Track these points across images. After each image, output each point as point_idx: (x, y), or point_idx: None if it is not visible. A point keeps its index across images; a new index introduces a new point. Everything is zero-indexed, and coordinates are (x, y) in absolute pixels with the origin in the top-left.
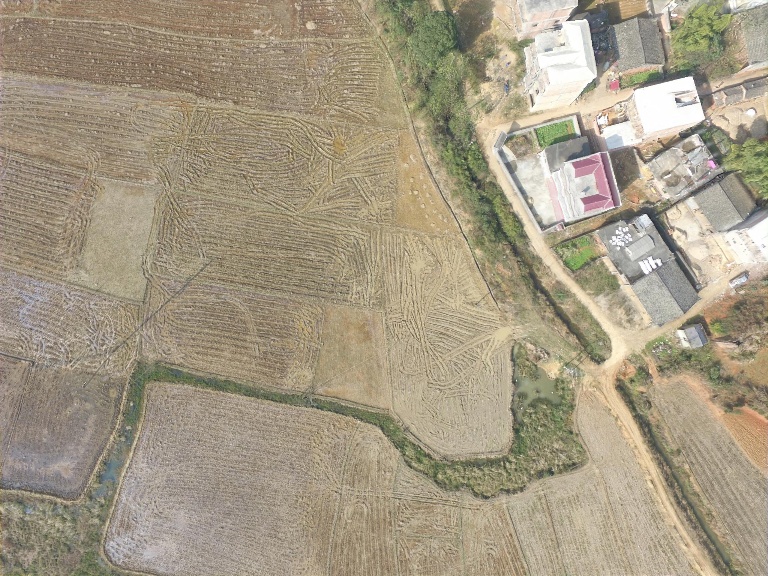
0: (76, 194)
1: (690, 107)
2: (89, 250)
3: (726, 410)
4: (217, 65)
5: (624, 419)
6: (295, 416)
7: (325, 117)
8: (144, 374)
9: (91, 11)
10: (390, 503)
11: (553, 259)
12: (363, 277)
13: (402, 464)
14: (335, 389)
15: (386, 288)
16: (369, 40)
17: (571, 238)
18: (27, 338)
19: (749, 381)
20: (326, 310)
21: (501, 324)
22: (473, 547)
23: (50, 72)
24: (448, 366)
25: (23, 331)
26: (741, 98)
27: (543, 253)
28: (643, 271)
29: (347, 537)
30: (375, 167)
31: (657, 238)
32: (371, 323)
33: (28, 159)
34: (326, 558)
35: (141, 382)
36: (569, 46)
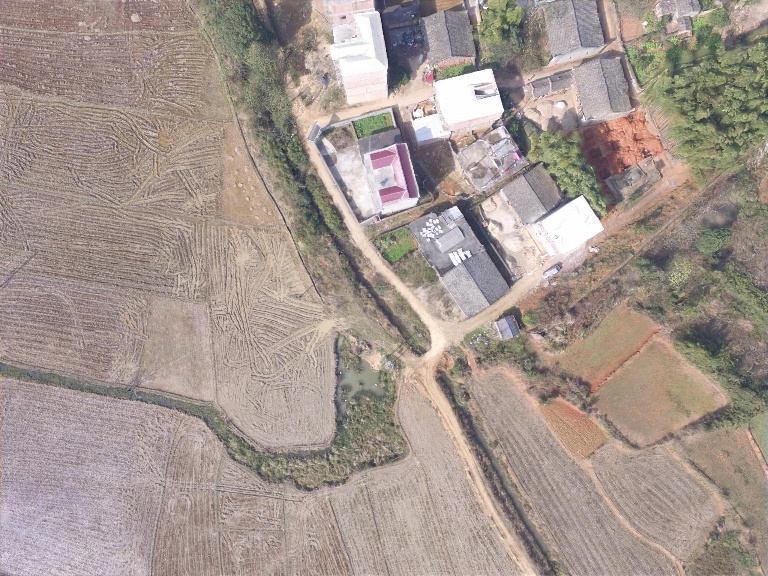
0: None
1: (489, 99)
2: None
3: (539, 401)
4: (42, 57)
5: (444, 411)
6: (119, 409)
7: (150, 110)
8: None
9: None
10: (213, 496)
11: (373, 251)
12: (188, 270)
13: (226, 457)
14: (159, 382)
15: (210, 281)
16: (194, 33)
17: (389, 230)
18: None
19: (564, 372)
20: (151, 303)
21: (325, 316)
22: (295, 539)
23: None
24: (272, 358)
25: None
26: (548, 90)
27: (363, 245)
28: (453, 263)
29: (170, 530)
30: (200, 160)
31: (467, 230)
32: (196, 316)
33: None
34: (149, 551)
35: None
36: (360, 38)
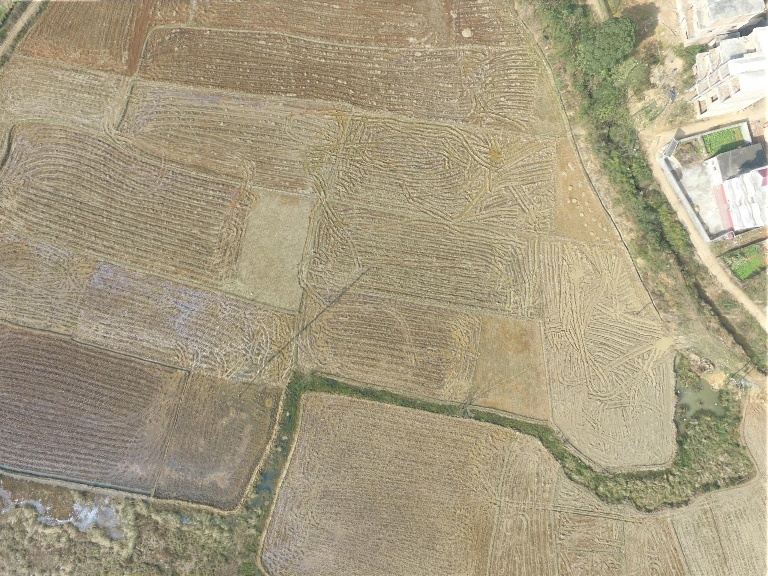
0: (231, 203)
1: None
2: (244, 259)
3: None
4: (372, 74)
5: None
6: (452, 427)
7: (481, 125)
8: (300, 384)
9: (246, 21)
10: (550, 516)
11: (720, 268)
12: (521, 286)
13: (562, 476)
14: (493, 400)
15: (545, 298)
16: (526, 47)
17: (739, 247)
18: (183, 347)
19: None
20: (483, 320)
21: (663, 334)
22: (636, 561)
23: (206, 82)
24: (609, 377)
25: (179, 340)
26: None
27: (709, 262)
28: None
29: (506, 550)
30: (533, 175)
31: None
32: (529, 333)
33: (184, 169)
34: (485, 571)
35: (297, 392)
36: (761, 52)
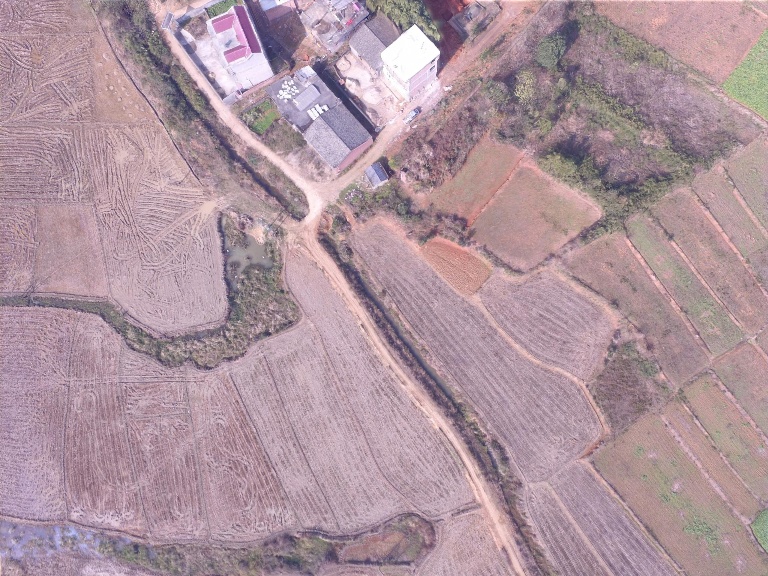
0: None
1: None
2: None
3: (418, 242)
4: None
5: (330, 270)
6: (18, 316)
7: (20, 32)
8: None
9: None
10: (117, 388)
11: (241, 127)
12: (70, 174)
13: (125, 348)
14: (54, 285)
15: (93, 181)
16: None
17: (253, 104)
18: None
19: (439, 212)
20: (39, 211)
21: (205, 199)
22: (201, 419)
23: None
24: (159, 246)
25: None
26: None
27: (231, 123)
28: (312, 119)
29: (79, 428)
30: (71, 70)
31: (322, 86)
32: (83, 217)
33: None
34: (60, 452)
35: None
36: None
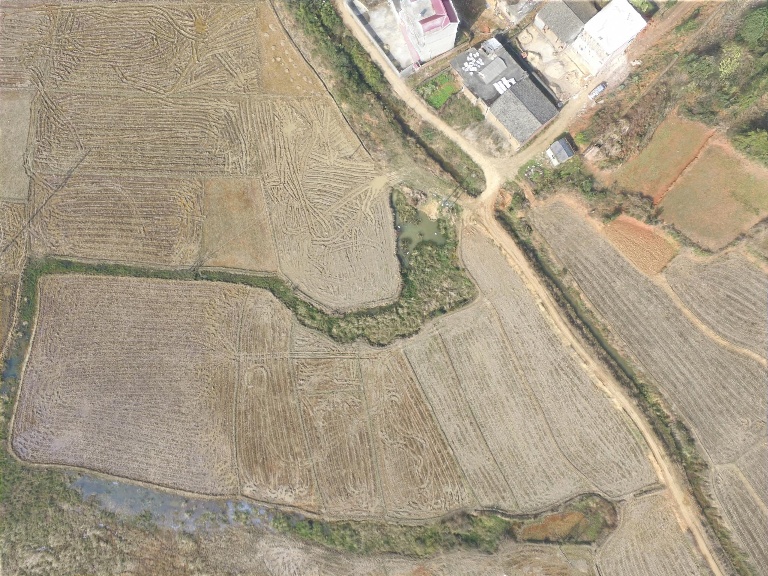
0: None
1: None
2: None
3: (603, 220)
4: None
5: (507, 247)
6: (186, 290)
7: (184, 1)
8: (35, 269)
9: None
10: (288, 363)
11: (416, 101)
12: (237, 147)
13: (296, 323)
14: (222, 259)
15: (260, 154)
16: None
17: (430, 77)
18: None
19: (623, 190)
20: (205, 184)
21: (376, 173)
22: (375, 396)
23: None
24: (330, 221)
25: None
26: None
27: (406, 96)
28: (498, 92)
29: (250, 403)
30: (237, 41)
31: (508, 59)
32: (250, 190)
33: None
34: (231, 427)
35: (33, 277)
36: None
